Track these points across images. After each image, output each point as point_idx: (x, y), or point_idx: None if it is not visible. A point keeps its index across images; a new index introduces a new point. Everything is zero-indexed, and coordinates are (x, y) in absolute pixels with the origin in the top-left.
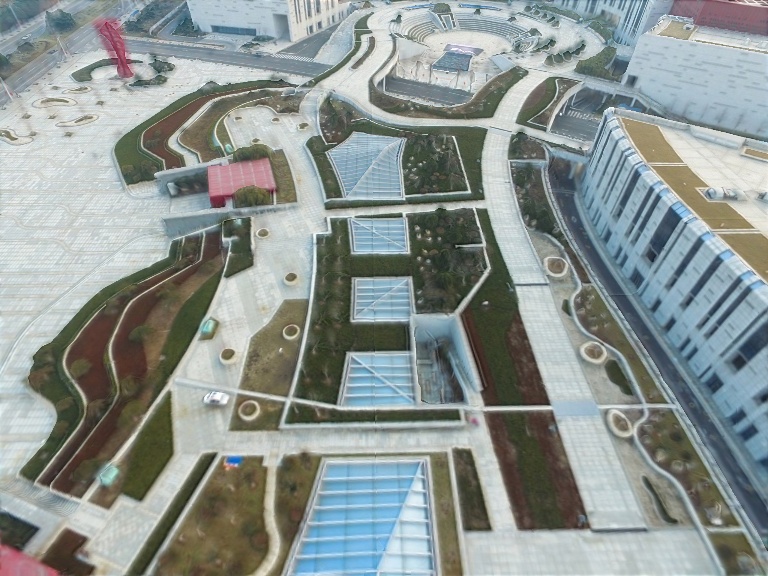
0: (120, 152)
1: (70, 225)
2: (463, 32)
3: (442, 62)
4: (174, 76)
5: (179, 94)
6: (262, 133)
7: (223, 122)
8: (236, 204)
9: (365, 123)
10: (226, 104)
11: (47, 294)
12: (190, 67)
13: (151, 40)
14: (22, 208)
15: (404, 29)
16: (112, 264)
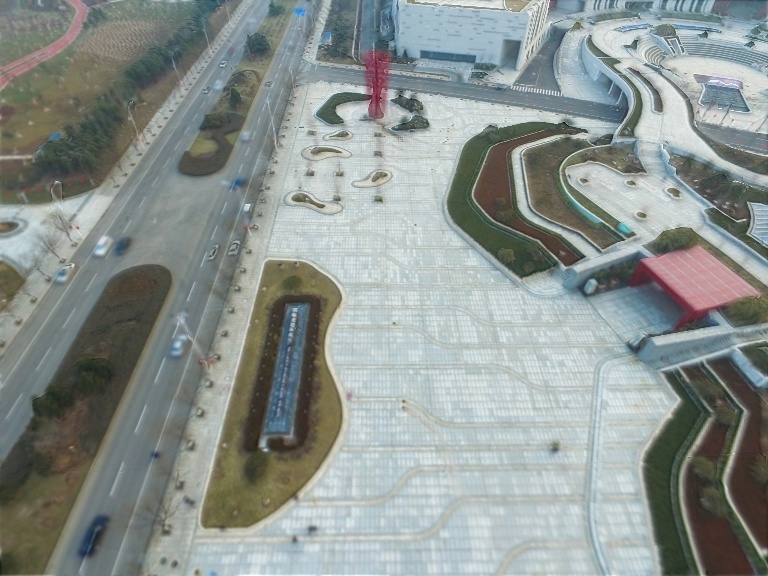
0: (468, 227)
1: (497, 341)
2: (693, 58)
3: (709, 97)
4: (430, 116)
5: (455, 141)
6: (632, 202)
7: (572, 186)
8: (731, 320)
9: (748, 189)
10: (542, 158)
11: (567, 463)
12: (437, 104)
13: (364, 68)
14: (413, 313)
15: (641, 56)
16: (612, 410)
